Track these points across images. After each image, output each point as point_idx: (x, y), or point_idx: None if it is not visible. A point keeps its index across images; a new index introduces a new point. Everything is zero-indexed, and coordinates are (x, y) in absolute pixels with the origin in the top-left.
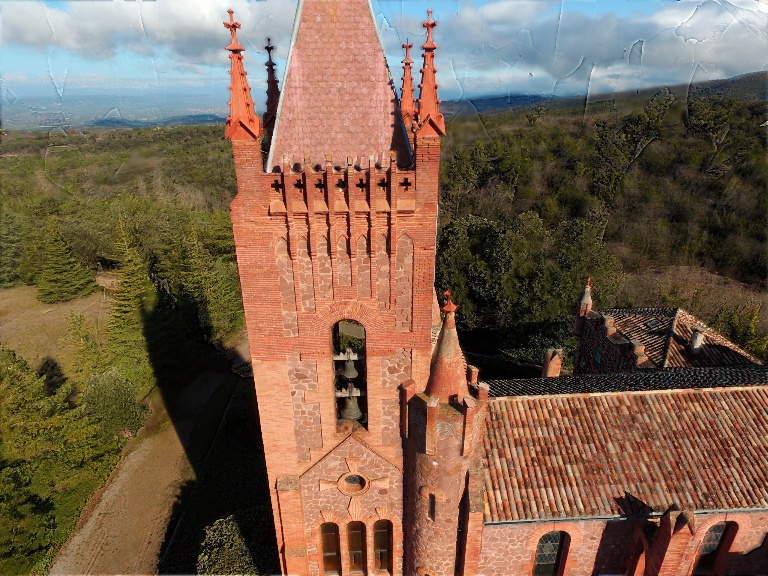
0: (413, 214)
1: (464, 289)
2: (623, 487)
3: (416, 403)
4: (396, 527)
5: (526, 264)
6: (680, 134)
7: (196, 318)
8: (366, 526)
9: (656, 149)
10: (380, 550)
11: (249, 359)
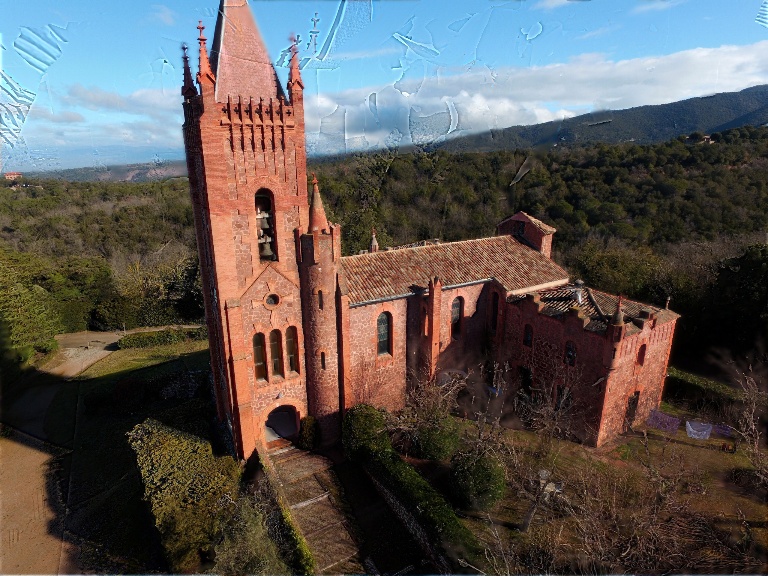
0: (293, 128)
1: None
2: (411, 283)
3: (305, 235)
4: (299, 331)
5: None
6: (411, 160)
7: (8, 339)
8: (281, 333)
9: (398, 166)
10: (290, 356)
11: (81, 369)
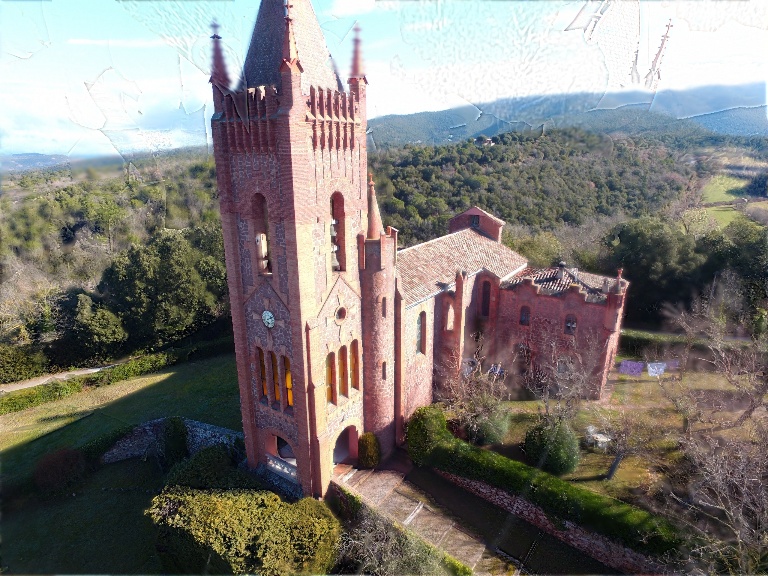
0: (359, 126)
1: (203, 283)
2: (435, 280)
3: (370, 241)
4: (359, 344)
5: None
6: None
7: None
8: (347, 349)
9: None
10: None
11: None
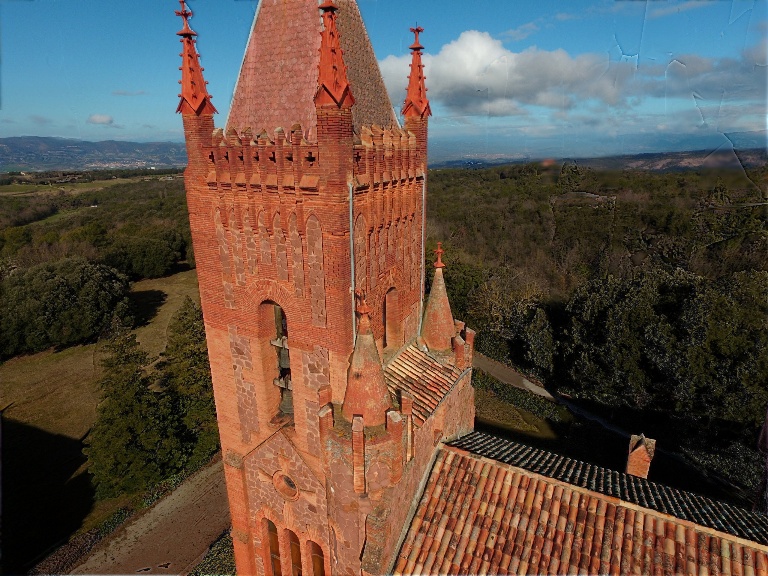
0: (318, 192)
1: (634, 354)
2: None
3: None
4: (326, 558)
5: (731, 339)
6: None
7: None
8: (299, 541)
9: None
10: None
11: None
